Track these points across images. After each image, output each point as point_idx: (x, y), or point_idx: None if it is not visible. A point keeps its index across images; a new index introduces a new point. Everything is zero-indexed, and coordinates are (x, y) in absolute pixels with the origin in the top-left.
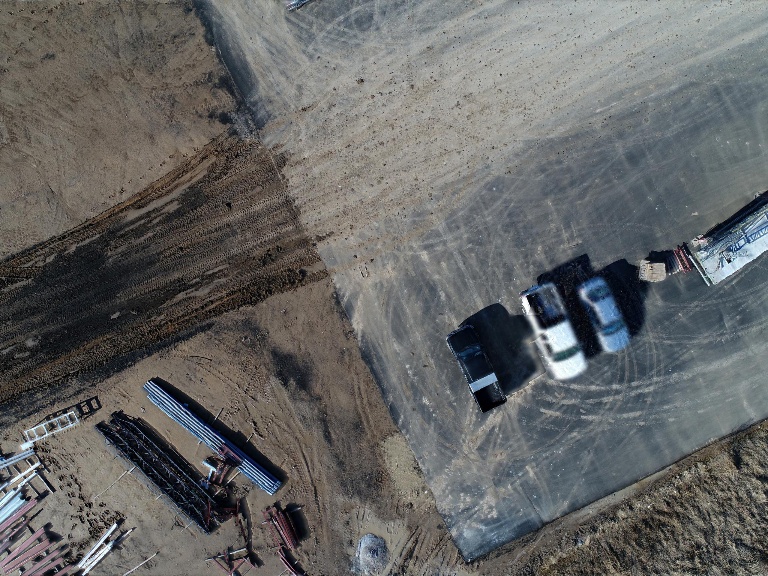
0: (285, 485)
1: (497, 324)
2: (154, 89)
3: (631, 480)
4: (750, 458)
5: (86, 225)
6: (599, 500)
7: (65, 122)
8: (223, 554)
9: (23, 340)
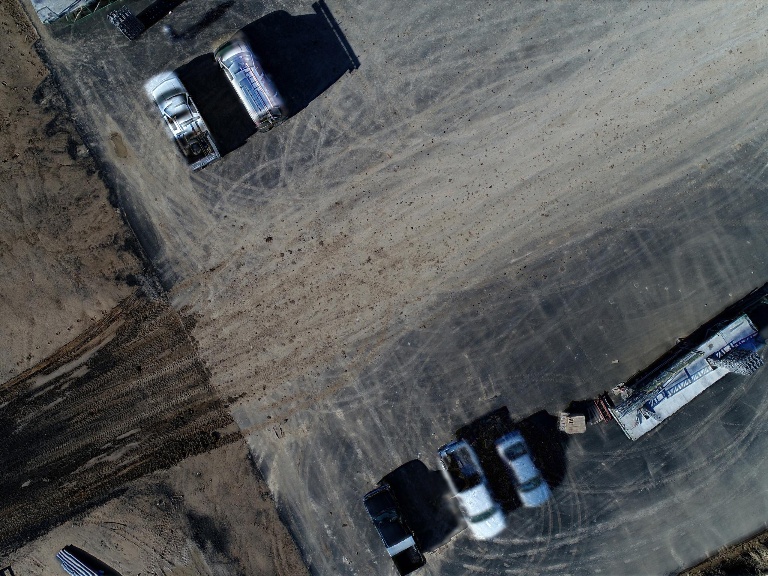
0: None
1: (416, 480)
2: (59, 252)
3: None
4: None
5: None
6: None
7: None
8: None
9: None
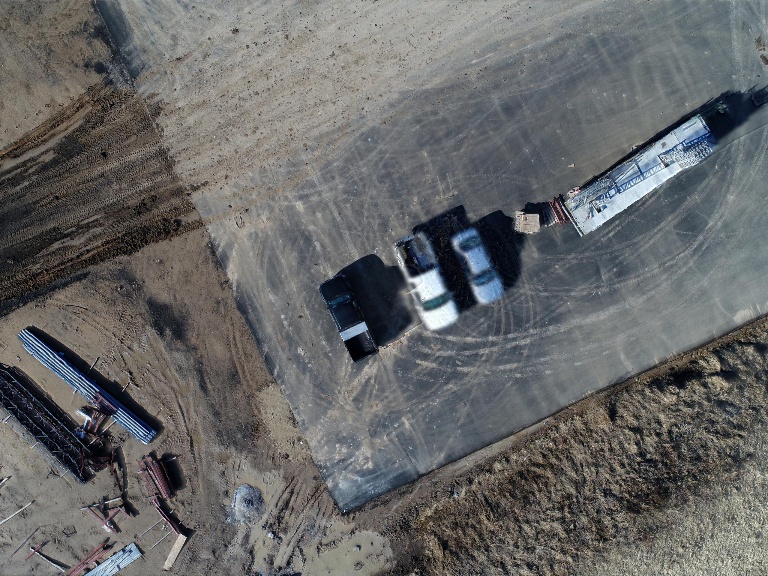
0: (161, 435)
1: (372, 275)
2: (30, 38)
3: (507, 432)
4: (625, 410)
5: None
6: (476, 452)
7: None
8: (98, 503)
9: None
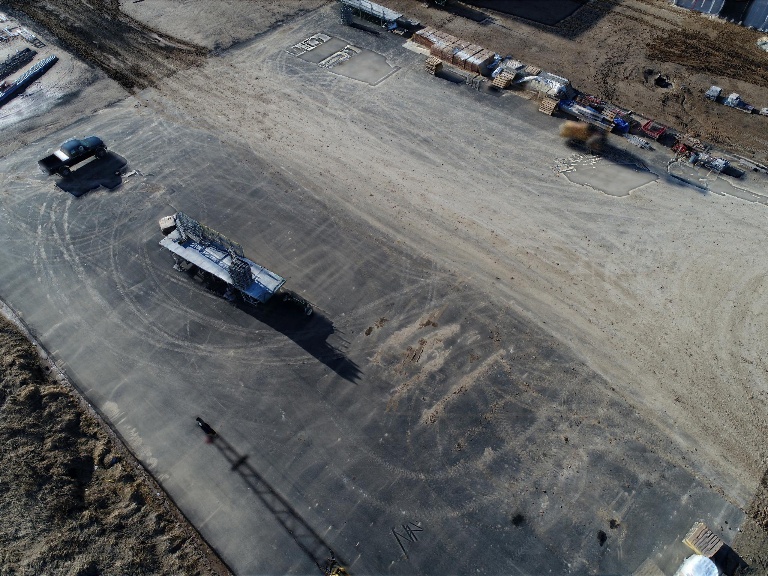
0: None
1: (112, 165)
2: None
3: None
4: None
5: None
6: None
7: None
8: None
9: (77, 23)
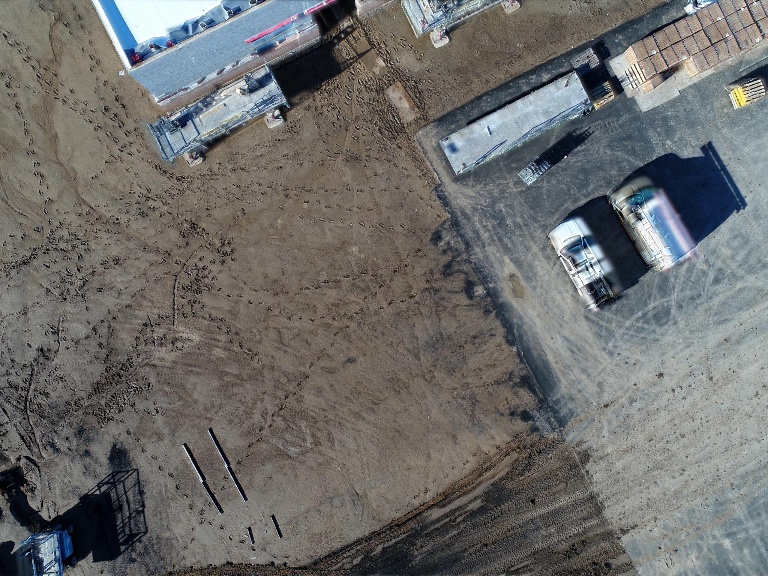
0: None
1: None
2: (455, 389)
3: None
4: None
5: (391, 525)
6: None
7: (368, 425)
8: None
9: None
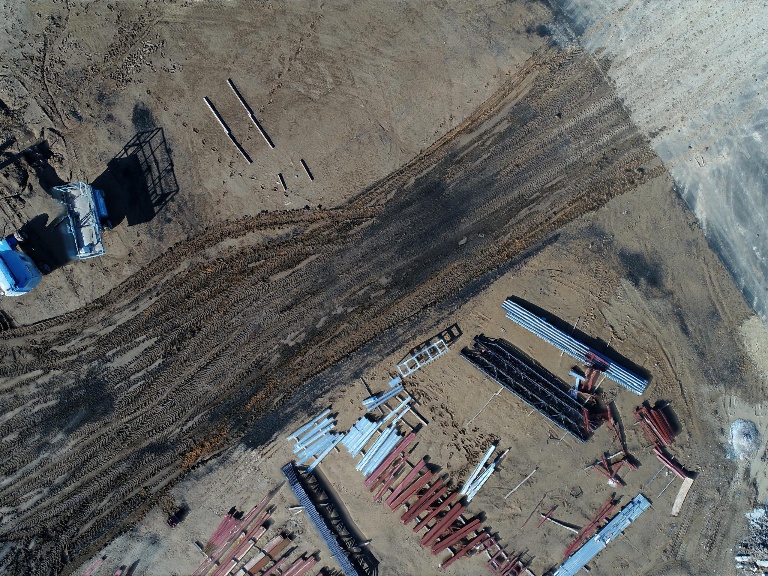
0: (650, 384)
1: None
2: (468, 13)
3: None
4: None
5: (421, 157)
6: None
7: (386, 59)
8: (601, 460)
9: (376, 279)
